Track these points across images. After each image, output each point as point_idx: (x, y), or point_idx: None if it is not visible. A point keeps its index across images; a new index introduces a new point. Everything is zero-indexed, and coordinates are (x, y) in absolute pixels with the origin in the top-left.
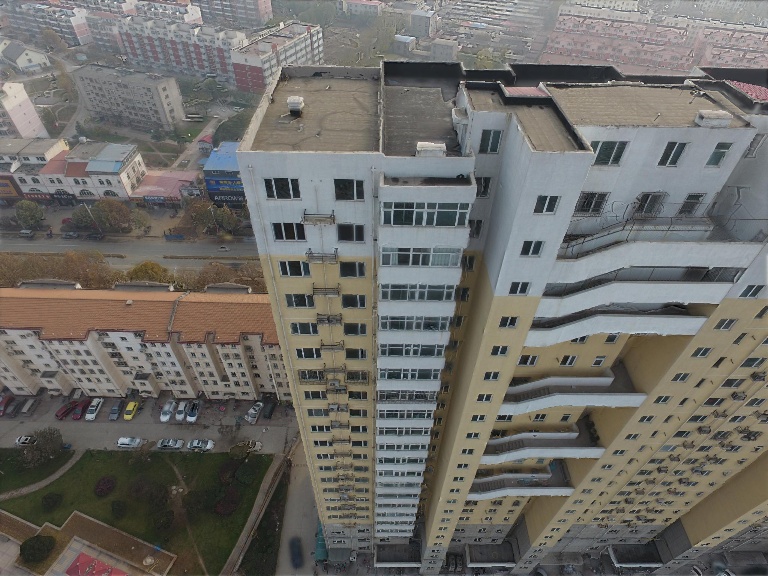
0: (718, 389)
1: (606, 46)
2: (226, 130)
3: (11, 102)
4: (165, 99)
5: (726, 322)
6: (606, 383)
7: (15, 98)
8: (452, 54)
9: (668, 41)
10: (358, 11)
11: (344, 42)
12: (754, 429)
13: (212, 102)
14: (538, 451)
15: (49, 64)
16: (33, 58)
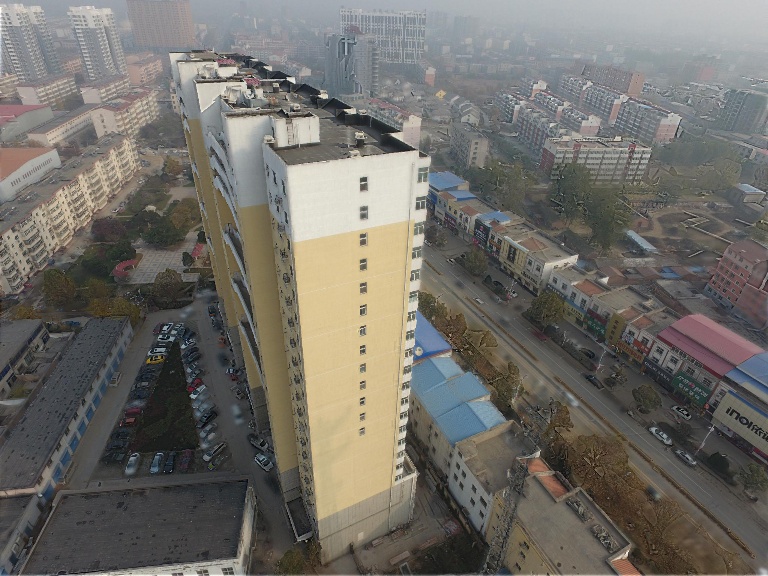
0: None
1: None
2: (471, 172)
3: (408, 125)
4: (474, 149)
5: None
6: None
7: (412, 124)
8: None
9: None
10: (763, 162)
11: (665, 168)
12: None
13: None
14: None
15: (477, 125)
16: (471, 119)
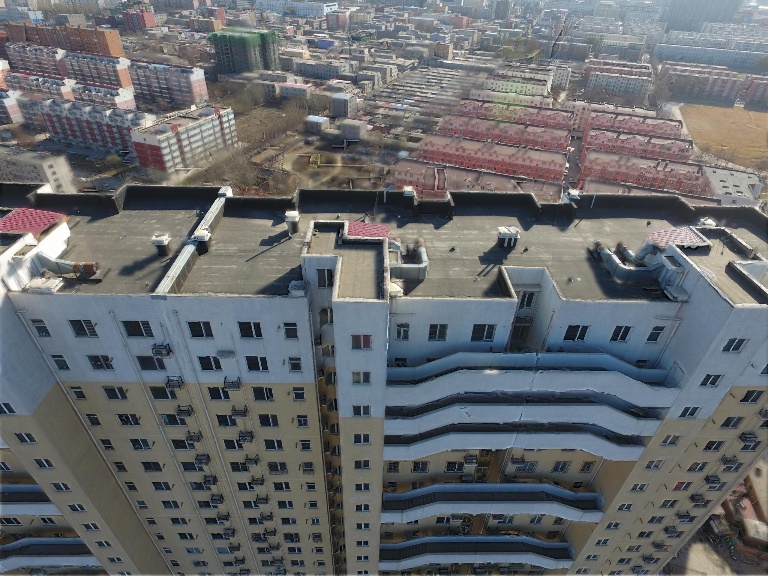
0: (192, 492)
1: (493, 127)
2: None
3: None
4: (51, 176)
5: (25, 436)
6: (38, 489)
7: None
8: (359, 133)
9: (558, 123)
10: (289, 93)
11: (254, 122)
12: (286, 530)
13: (114, 177)
14: (27, 559)
15: None
16: None
